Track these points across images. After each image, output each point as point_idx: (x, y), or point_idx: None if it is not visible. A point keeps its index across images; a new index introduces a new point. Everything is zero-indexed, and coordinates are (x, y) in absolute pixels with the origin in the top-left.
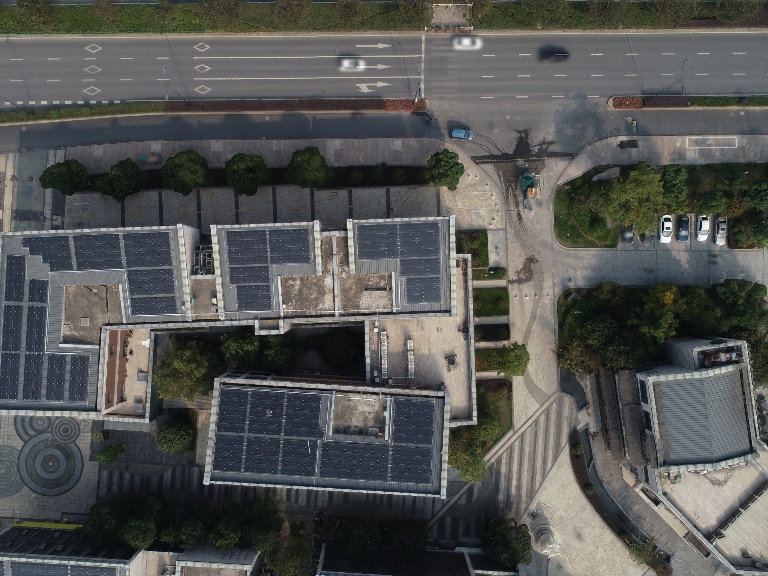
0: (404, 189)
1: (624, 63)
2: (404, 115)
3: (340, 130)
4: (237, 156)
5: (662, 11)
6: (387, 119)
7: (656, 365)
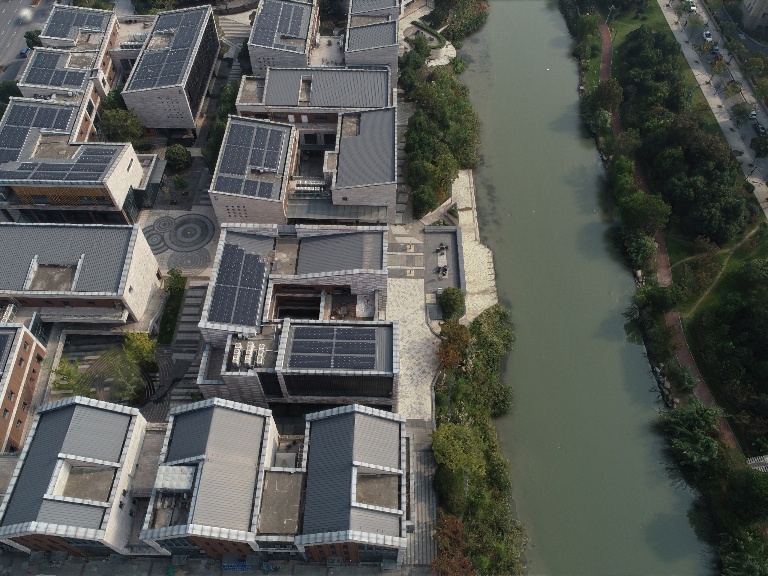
0: None
1: (14, 3)
2: (3, 74)
3: None
4: None
5: None
6: (2, 81)
7: None
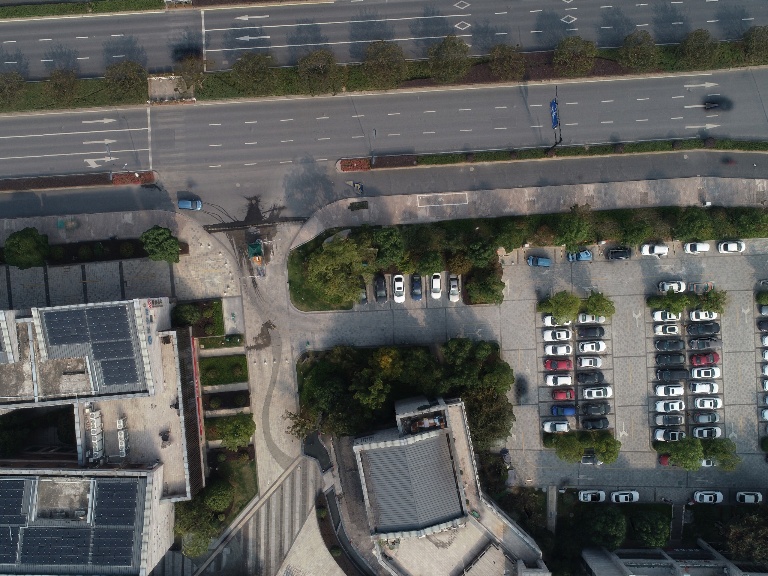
0: (137, 262)
1: (350, 125)
2: (133, 188)
3: (71, 206)
4: None
5: (370, 76)
6: (117, 193)
7: (382, 428)
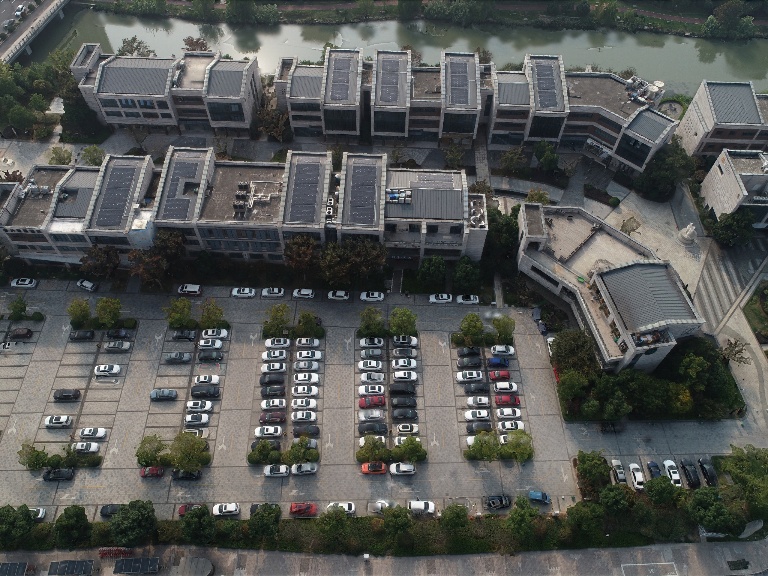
0: None
1: None
2: None
3: None
4: None
5: None
6: None
7: None
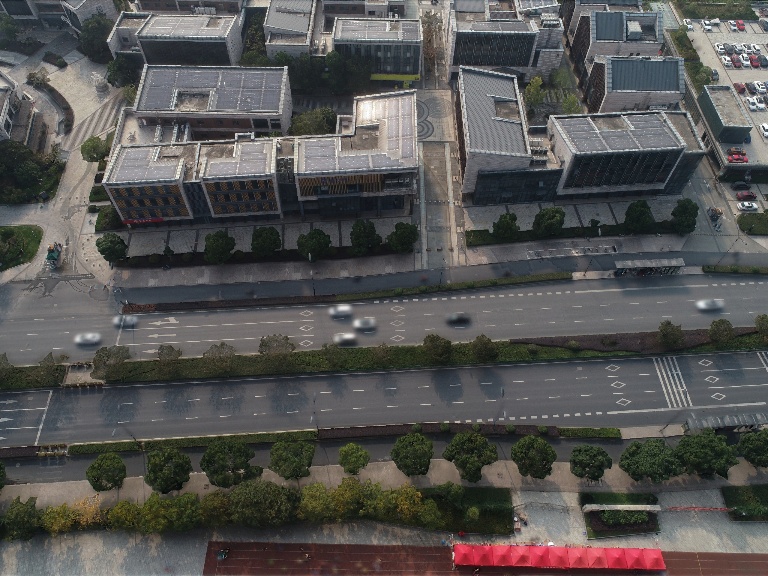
0: None
1: None
2: (142, 303)
3: (197, 291)
4: (268, 243)
5: None
6: (157, 300)
7: None
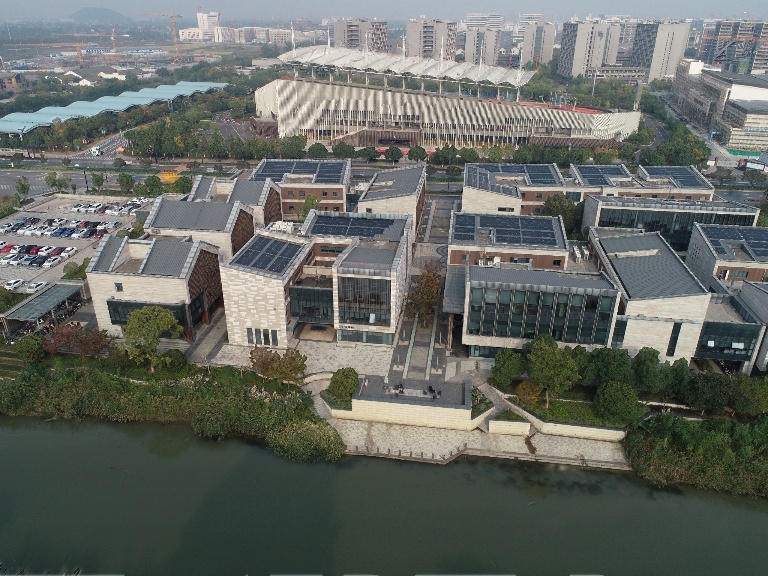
0: None
1: None
2: None
3: None
4: None
5: None
6: None
7: None
